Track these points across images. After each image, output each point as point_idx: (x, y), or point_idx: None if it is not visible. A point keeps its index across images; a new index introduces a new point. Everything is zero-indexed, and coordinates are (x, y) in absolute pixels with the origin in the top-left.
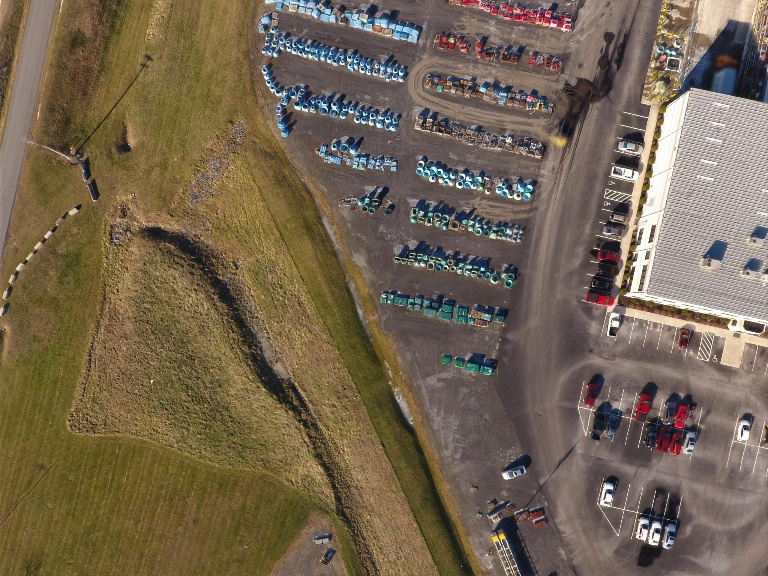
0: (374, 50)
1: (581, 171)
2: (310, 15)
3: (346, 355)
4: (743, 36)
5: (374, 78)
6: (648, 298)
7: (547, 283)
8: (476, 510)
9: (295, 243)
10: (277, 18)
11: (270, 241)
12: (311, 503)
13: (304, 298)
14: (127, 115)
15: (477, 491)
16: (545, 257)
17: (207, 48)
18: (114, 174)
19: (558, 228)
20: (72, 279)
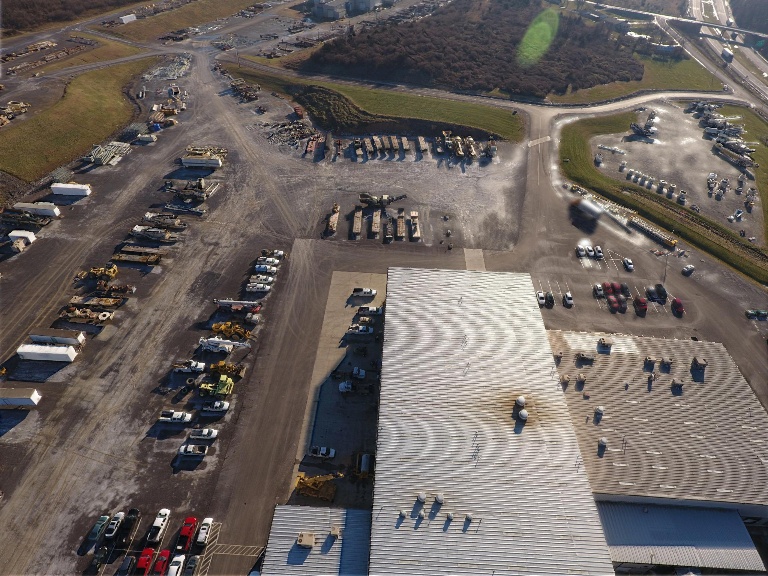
0: None
1: None
2: None
3: None
4: None
5: None
6: None
7: (761, 366)
8: (692, 253)
9: None
10: None
11: None
12: None
13: None
14: None
15: (700, 260)
16: None
17: None
18: None
19: None
20: None
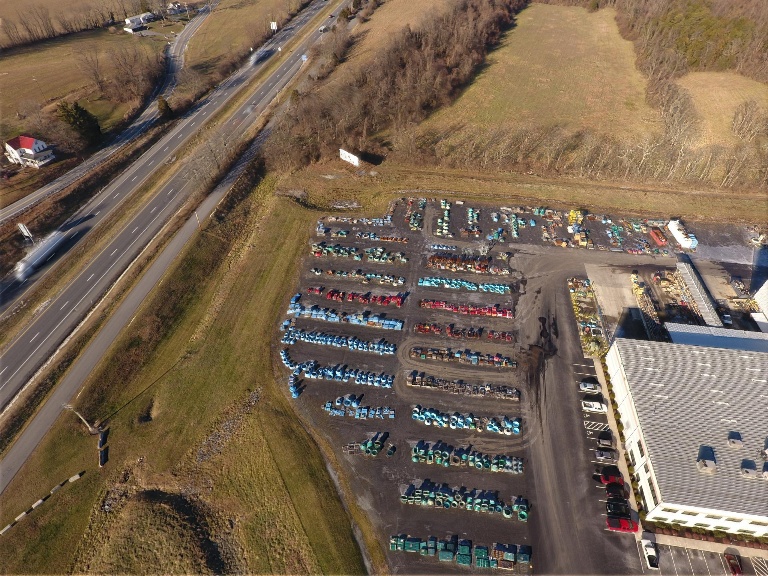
0: (369, 336)
1: (556, 408)
2: (320, 319)
3: None
4: (638, 315)
5: (370, 353)
6: (669, 515)
7: (562, 513)
8: None
9: (298, 490)
10: (295, 321)
11: (272, 491)
12: None
13: (304, 552)
14: (157, 393)
15: None
16: (551, 486)
17: (238, 342)
18: (129, 441)
19: (554, 457)
20: (40, 556)
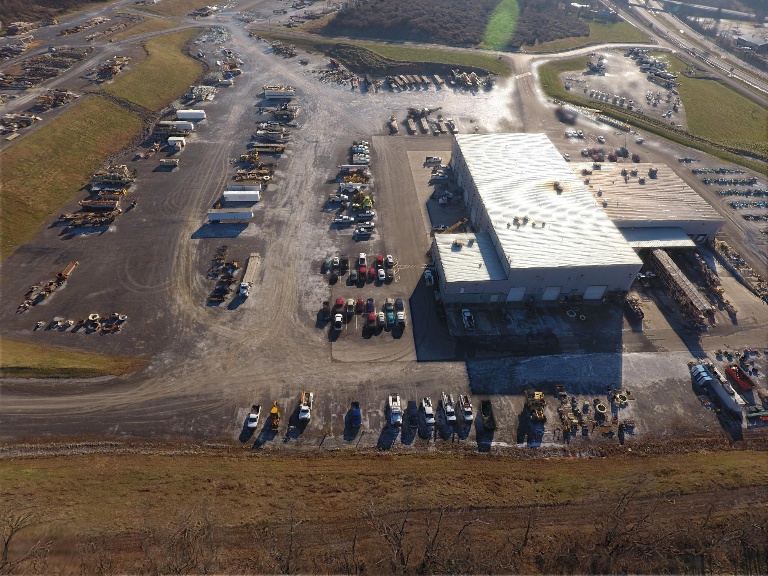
0: None
1: None
2: None
3: (736, 157)
4: None
5: None
6: None
7: (689, 182)
8: None
9: None
10: None
11: None
12: (693, 133)
13: None
14: None
15: None
16: None
17: None
18: None
19: (706, 197)
20: None
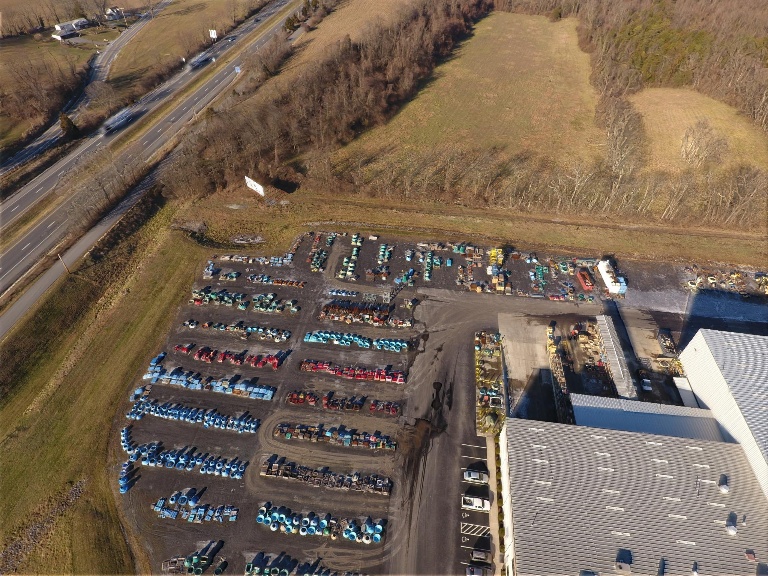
0: (231, 408)
1: (432, 505)
2: (180, 385)
3: None
4: (548, 378)
5: (227, 431)
6: None
7: None
8: None
9: None
10: (150, 389)
11: None
12: None
13: None
14: None
15: None
16: None
17: (76, 417)
18: None
19: (416, 575)
20: None
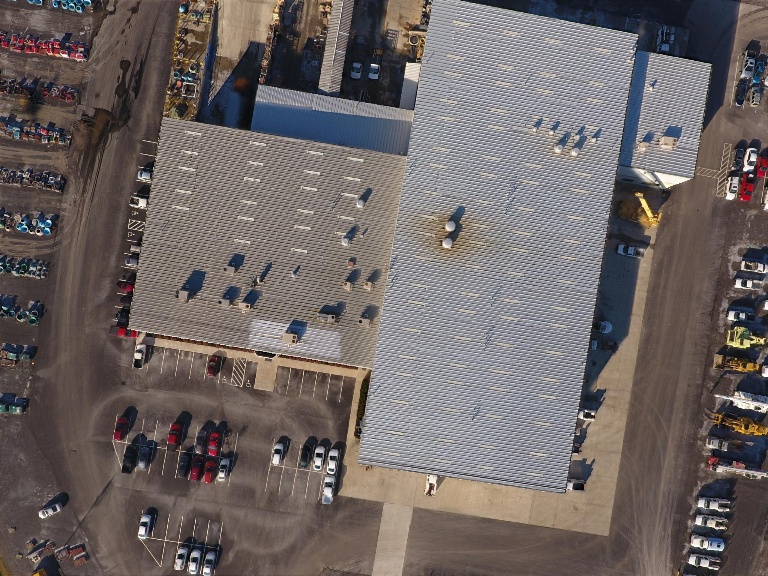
0: None
1: (103, 203)
2: None
3: None
4: None
5: None
6: None
7: (75, 318)
8: (16, 551)
9: None
10: None
11: None
12: None
13: None
14: None
15: (15, 532)
16: (71, 292)
17: None
18: None
19: (83, 262)
20: None
